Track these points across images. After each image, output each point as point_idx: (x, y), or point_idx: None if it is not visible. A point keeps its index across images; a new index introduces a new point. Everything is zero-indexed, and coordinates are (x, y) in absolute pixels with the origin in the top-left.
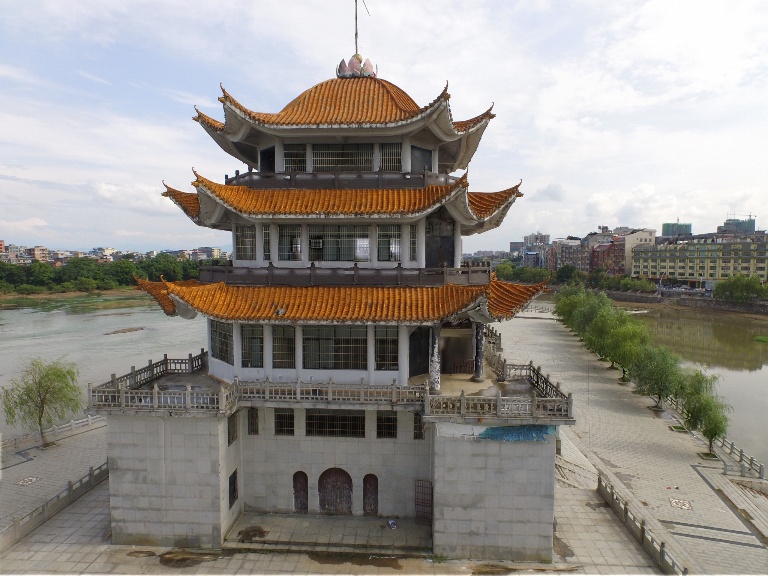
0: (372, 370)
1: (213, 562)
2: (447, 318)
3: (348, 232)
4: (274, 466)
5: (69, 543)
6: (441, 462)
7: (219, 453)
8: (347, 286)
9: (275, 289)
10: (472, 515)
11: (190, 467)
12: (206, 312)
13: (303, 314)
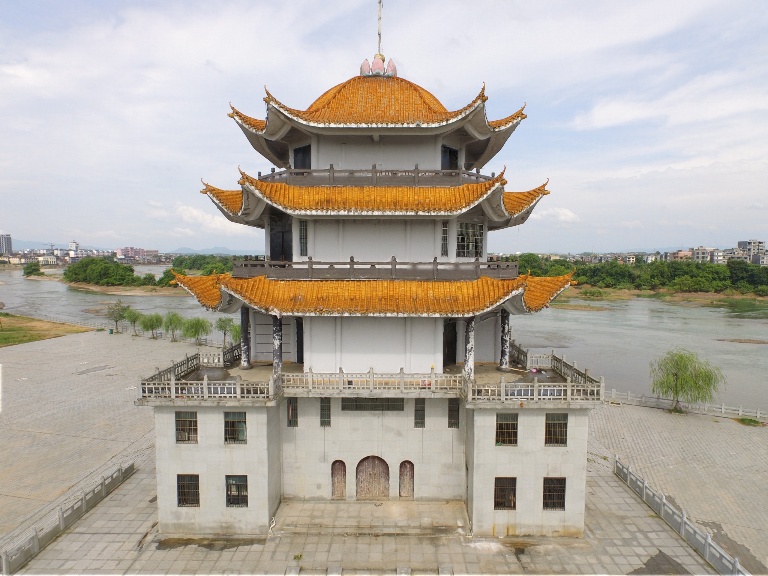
0: None
1: None
2: None
3: None
4: None
5: None
6: None
7: None
8: None
9: None
10: None
11: None
12: None
13: None
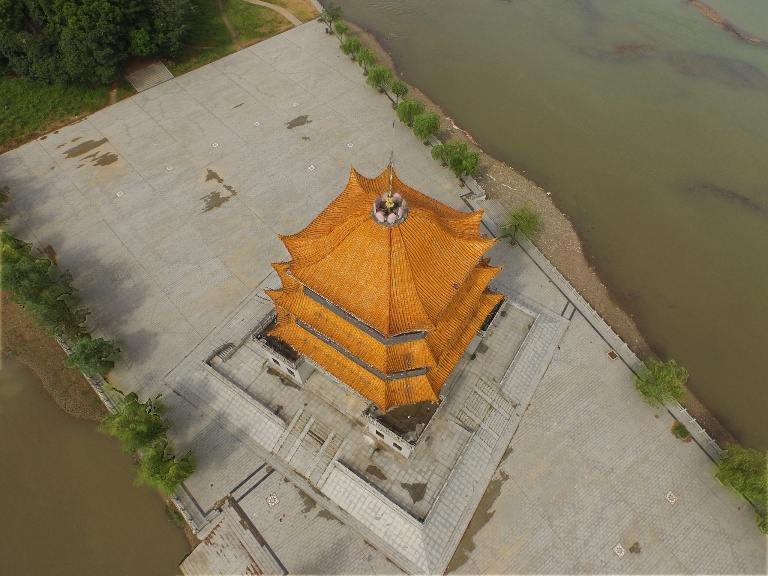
0: None
1: None
2: None
3: None
4: None
5: None
6: None
7: None
8: None
9: None
10: None
11: None
12: None
13: None
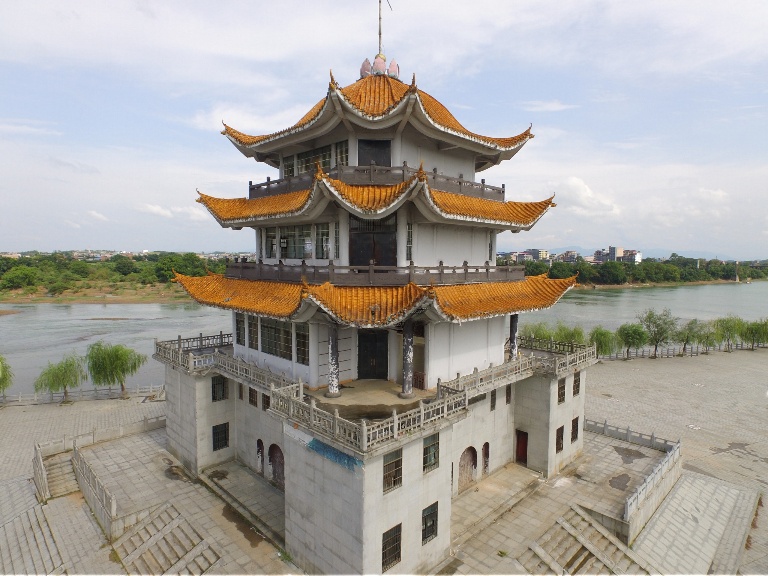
0: (294, 361)
1: (182, 482)
2: (292, 316)
3: (299, 232)
4: (249, 429)
5: (156, 441)
6: (288, 460)
7: (197, 404)
8: (274, 281)
9: (242, 281)
10: (306, 526)
11: (187, 409)
12: (192, 296)
13: (233, 303)
